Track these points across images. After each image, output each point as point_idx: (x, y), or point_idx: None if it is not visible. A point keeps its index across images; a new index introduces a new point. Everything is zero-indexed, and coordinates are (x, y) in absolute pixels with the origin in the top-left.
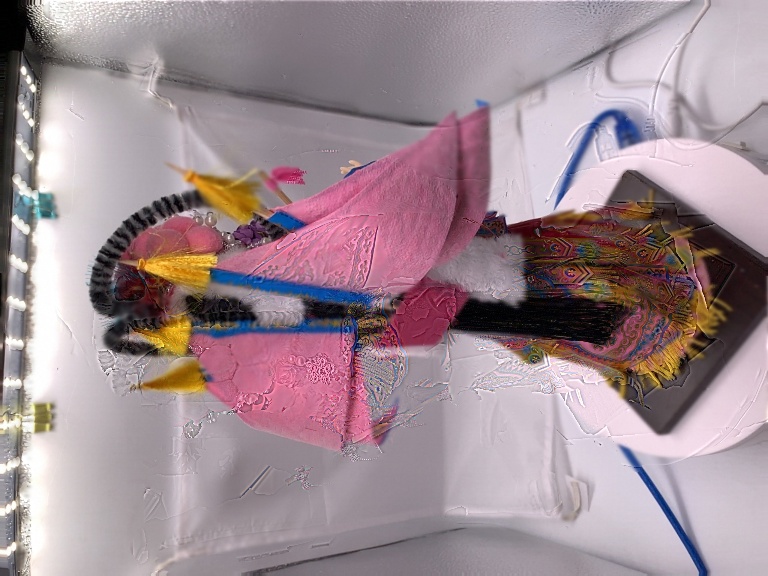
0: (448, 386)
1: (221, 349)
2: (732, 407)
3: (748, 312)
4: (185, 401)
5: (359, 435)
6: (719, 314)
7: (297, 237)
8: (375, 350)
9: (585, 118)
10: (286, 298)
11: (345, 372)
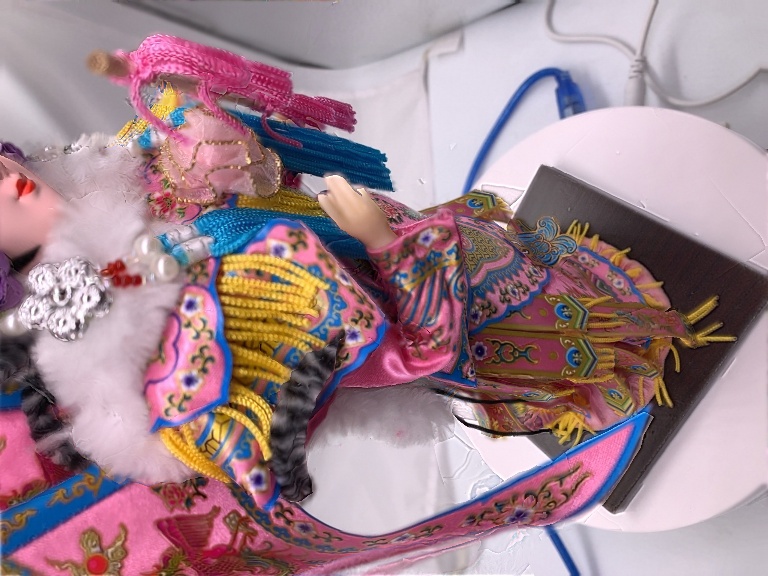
0: None
1: None
2: (621, 114)
3: (519, 153)
4: None
5: None
6: (527, 177)
7: None
8: None
9: (463, 499)
10: None
11: None
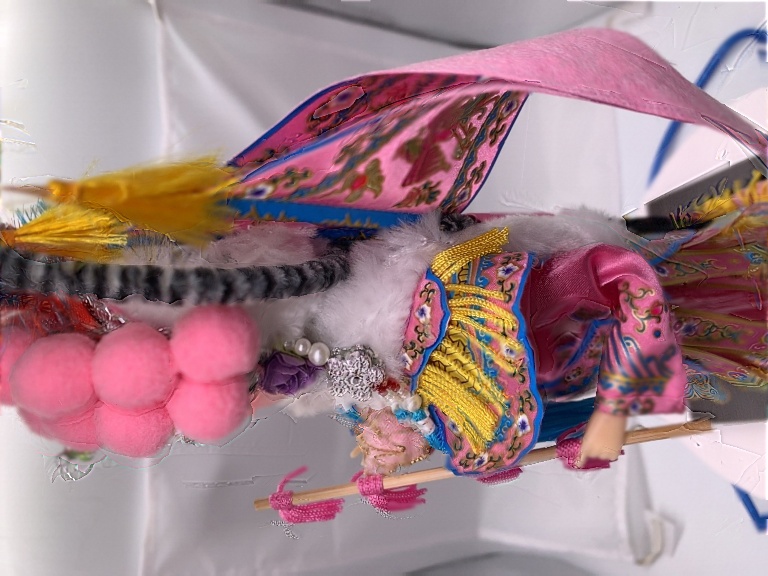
0: (582, 439)
1: (145, 344)
2: None
3: None
4: (54, 435)
5: (398, 480)
6: None
7: (370, 108)
8: (473, 367)
9: None
10: (313, 224)
11: (400, 383)
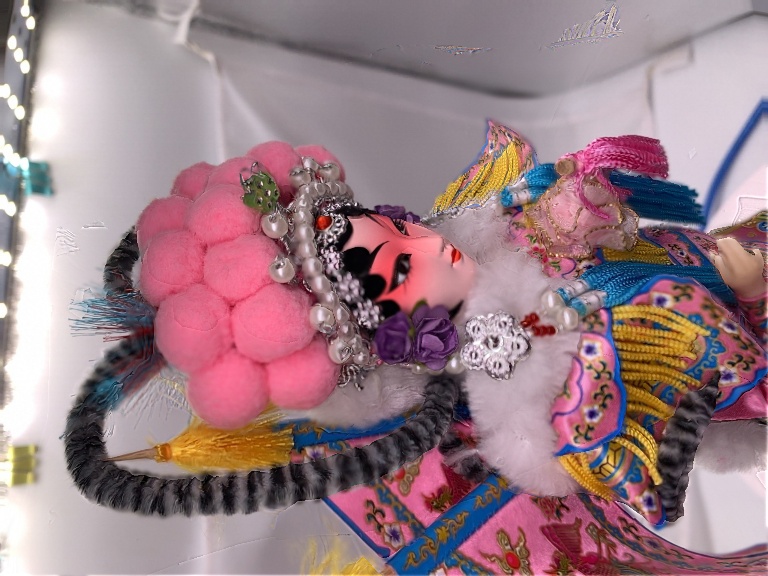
0: None
1: None
2: None
3: None
4: None
5: None
6: None
7: None
8: None
9: None
10: None
11: None
